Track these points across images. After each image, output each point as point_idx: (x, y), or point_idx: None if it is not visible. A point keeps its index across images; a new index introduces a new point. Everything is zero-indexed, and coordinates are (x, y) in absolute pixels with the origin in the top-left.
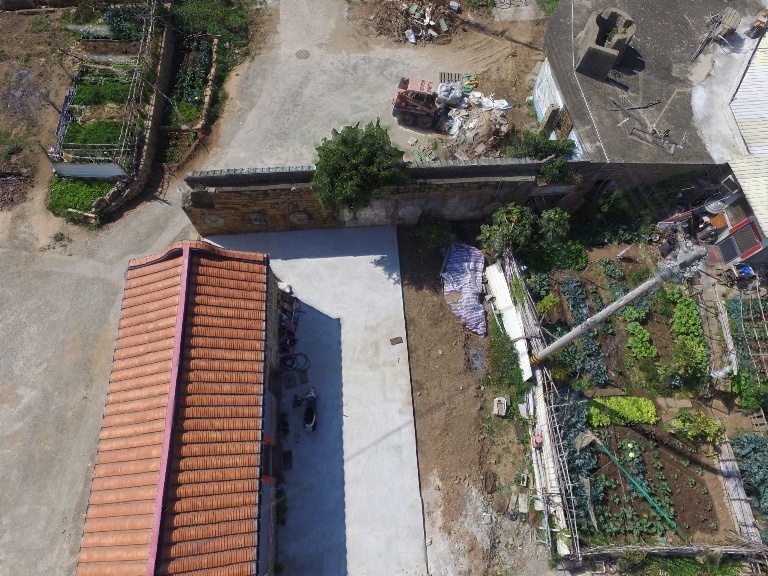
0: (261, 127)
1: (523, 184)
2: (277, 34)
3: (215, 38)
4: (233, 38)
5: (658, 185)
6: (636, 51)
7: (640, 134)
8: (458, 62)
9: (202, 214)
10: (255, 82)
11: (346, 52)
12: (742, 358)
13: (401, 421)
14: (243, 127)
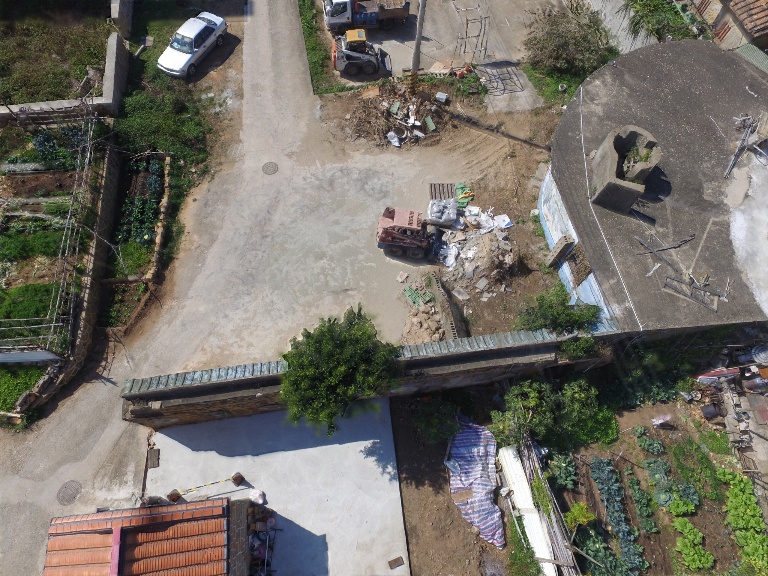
0: (224, 269)
1: (541, 364)
2: (240, 143)
3: (167, 156)
4: (189, 153)
5: (697, 336)
6: (659, 169)
7: (675, 285)
8: (449, 168)
9: (149, 419)
10: (216, 208)
11: (320, 162)
12: None
13: None
14: (202, 270)
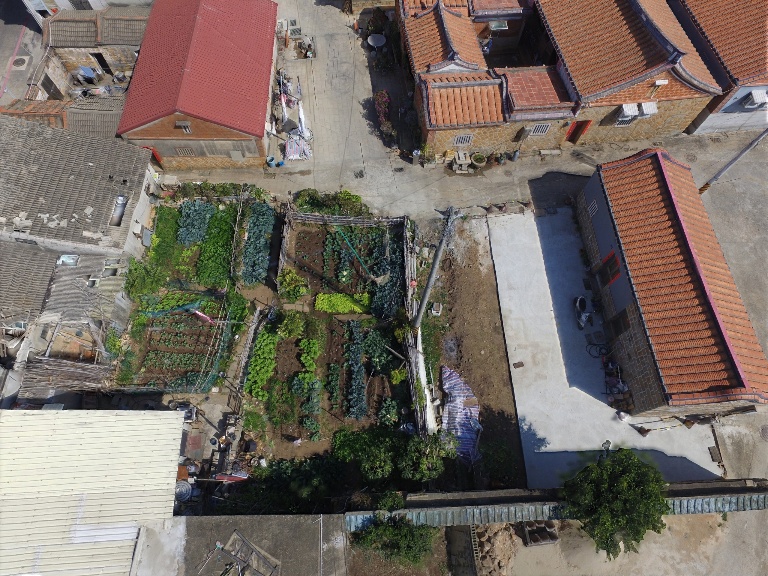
0: None
1: None
2: None
3: None
4: None
5: None
6: None
7: (264, 567)
8: None
9: None
10: None
11: None
12: (226, 337)
13: (510, 305)
14: None
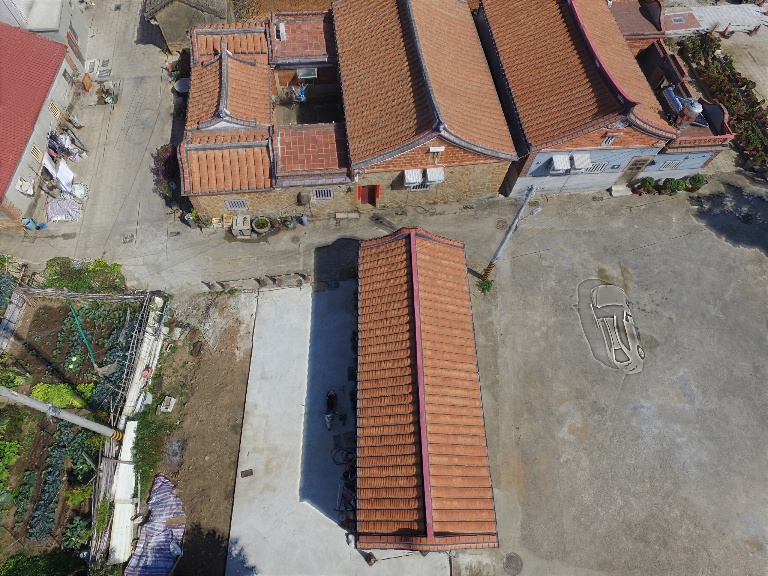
0: None
1: None
2: None
3: None
4: None
5: None
6: None
7: None
8: None
9: None
10: None
11: None
12: None
13: (257, 399)
14: None
